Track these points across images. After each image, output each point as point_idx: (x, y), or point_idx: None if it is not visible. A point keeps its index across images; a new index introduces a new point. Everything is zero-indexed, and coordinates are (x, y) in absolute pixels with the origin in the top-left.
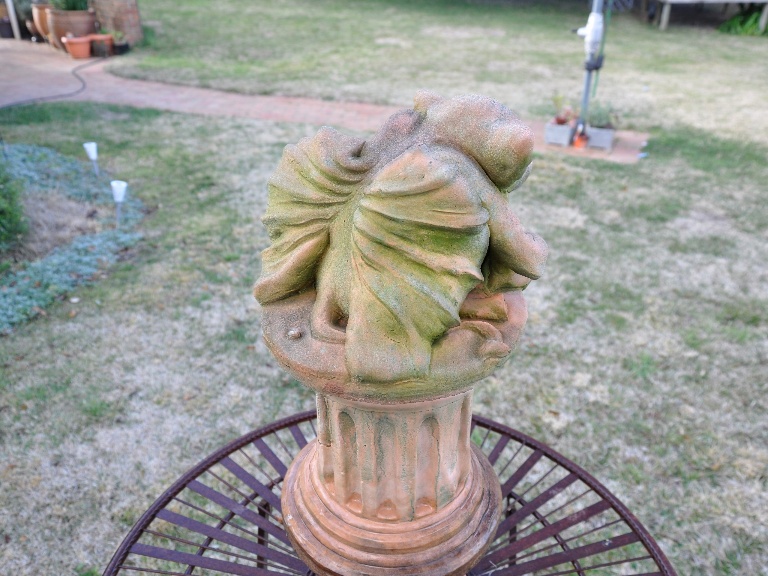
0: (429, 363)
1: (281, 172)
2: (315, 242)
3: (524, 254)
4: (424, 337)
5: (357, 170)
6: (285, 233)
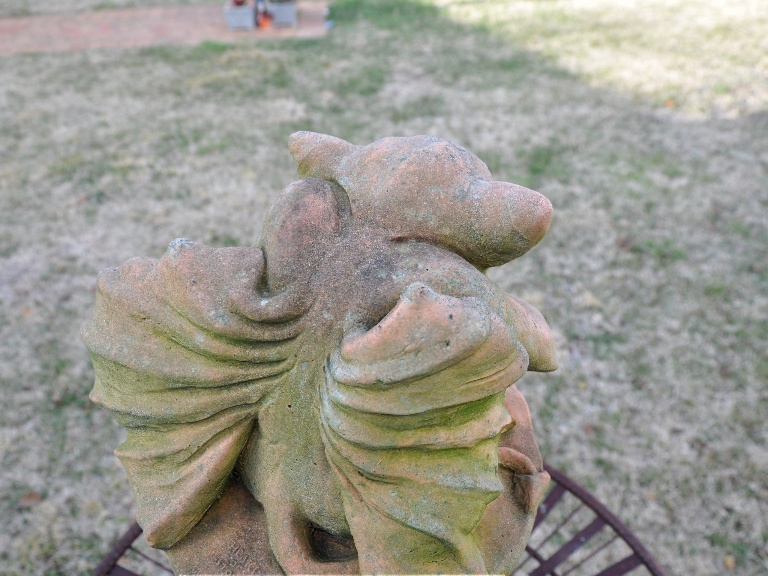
0: (483, 561)
1: (126, 339)
2: (236, 438)
3: (540, 355)
4: (469, 533)
5: (282, 321)
6: (173, 434)
